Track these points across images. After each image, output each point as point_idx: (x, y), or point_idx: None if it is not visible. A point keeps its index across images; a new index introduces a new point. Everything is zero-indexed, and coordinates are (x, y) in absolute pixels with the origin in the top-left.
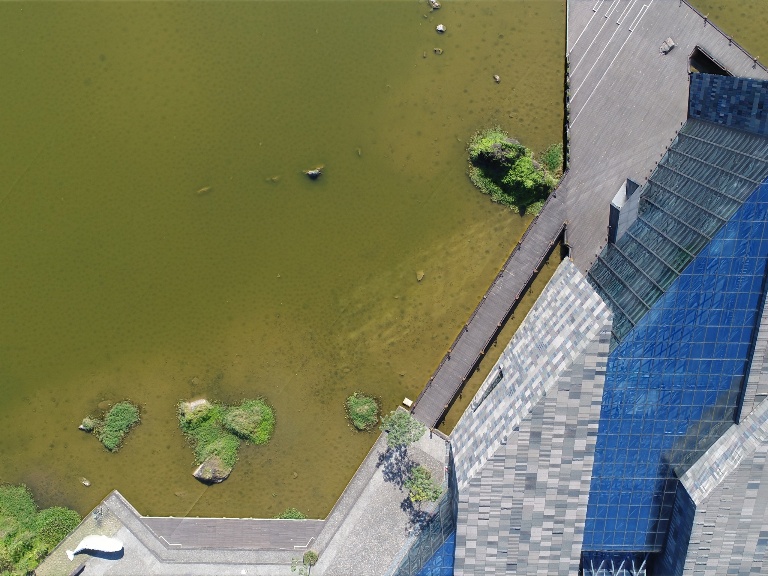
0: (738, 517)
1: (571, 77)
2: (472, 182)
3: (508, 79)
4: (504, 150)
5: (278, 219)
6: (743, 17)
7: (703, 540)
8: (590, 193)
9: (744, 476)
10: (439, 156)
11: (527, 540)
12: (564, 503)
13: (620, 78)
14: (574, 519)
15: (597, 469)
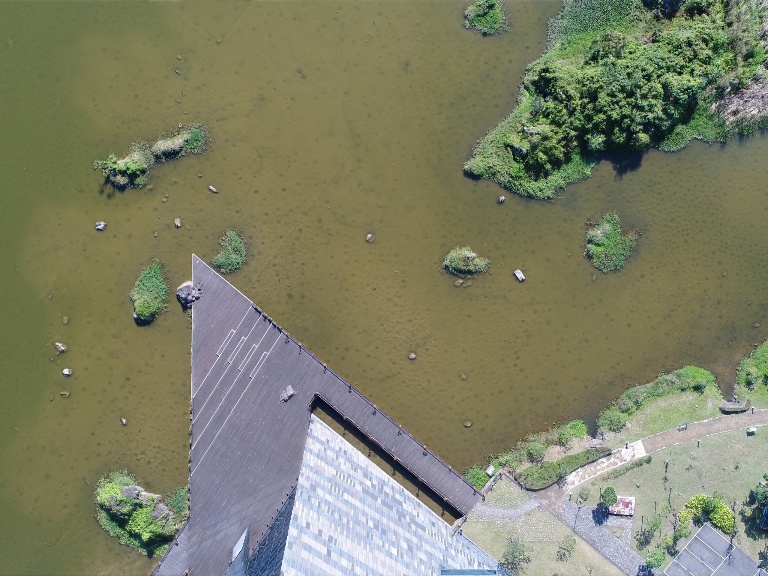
0: None
1: (194, 423)
2: (100, 525)
3: (135, 422)
4: (119, 505)
5: None
6: (369, 358)
7: None
8: (212, 541)
9: None
10: (67, 499)
11: None
12: None
13: (240, 426)
14: None
15: None
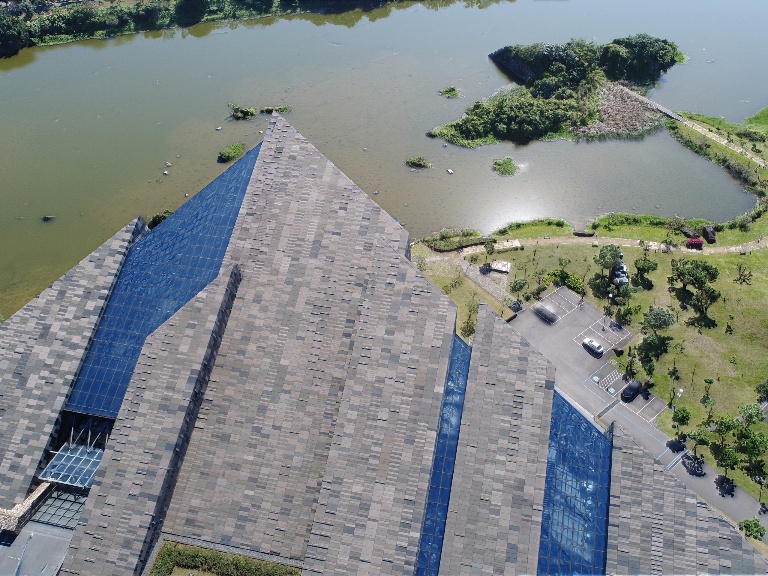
0: (176, 353)
1: None
2: None
3: None
4: (165, 213)
5: (8, 235)
6: None
7: (145, 371)
8: None
9: (186, 316)
10: None
11: (23, 386)
12: (63, 354)
13: None
14: (66, 371)
15: (100, 334)
